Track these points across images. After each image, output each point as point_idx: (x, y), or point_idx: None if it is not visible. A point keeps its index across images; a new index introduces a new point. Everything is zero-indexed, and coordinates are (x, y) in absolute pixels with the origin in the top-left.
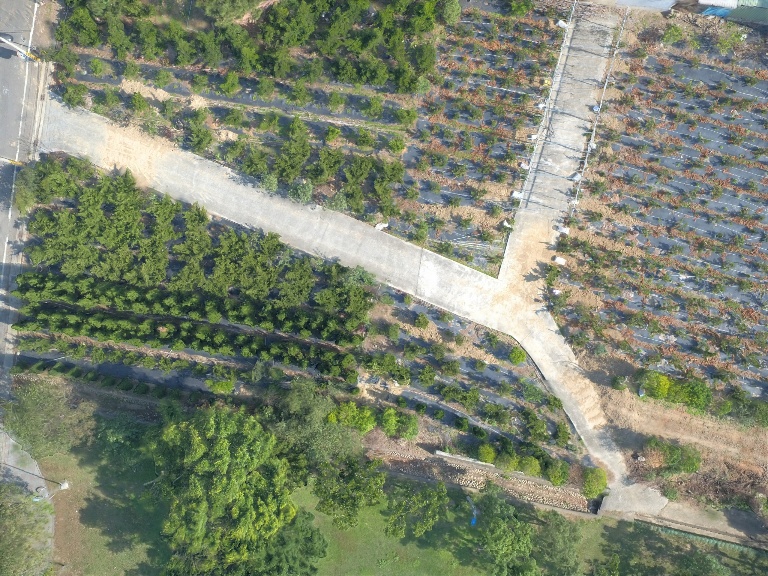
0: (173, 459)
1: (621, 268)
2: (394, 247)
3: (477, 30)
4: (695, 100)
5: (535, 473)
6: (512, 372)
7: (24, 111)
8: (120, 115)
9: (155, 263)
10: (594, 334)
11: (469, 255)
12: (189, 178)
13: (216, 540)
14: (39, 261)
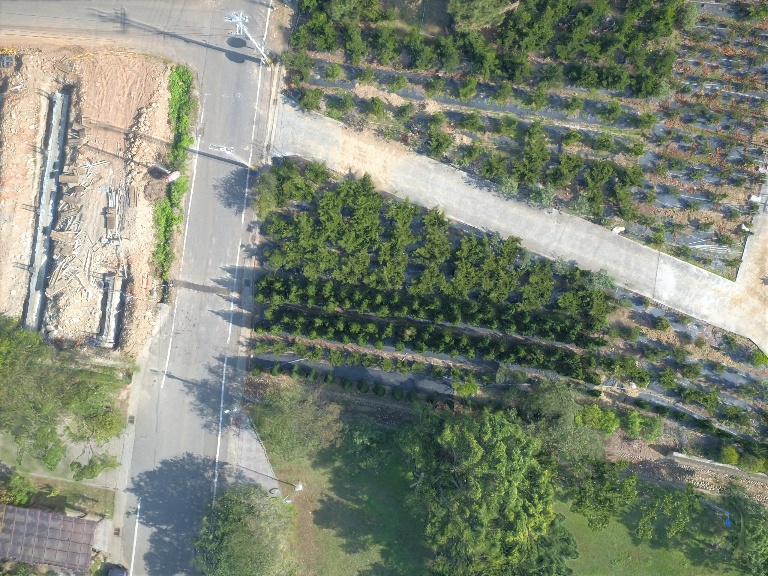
0: (429, 461)
1: None
2: (631, 250)
3: (712, 35)
4: None
5: None
6: (749, 374)
7: (257, 115)
8: (354, 119)
9: (395, 266)
10: None
11: (706, 258)
12: (425, 182)
13: (496, 541)
14: (280, 264)
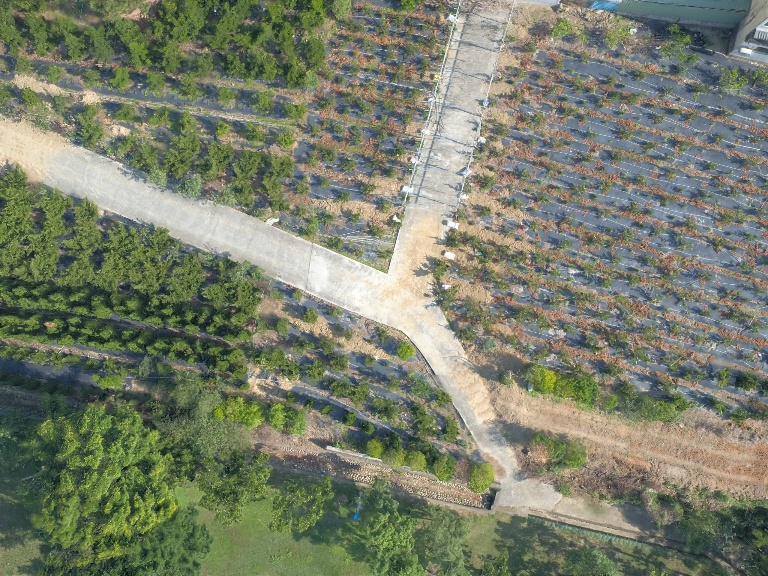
0: None
1: (510, 263)
2: (284, 242)
3: (368, 25)
4: (585, 94)
5: (421, 468)
6: (402, 367)
7: None
8: (12, 110)
9: (45, 258)
10: (484, 329)
11: (359, 250)
12: (81, 173)
13: (87, 535)
14: None
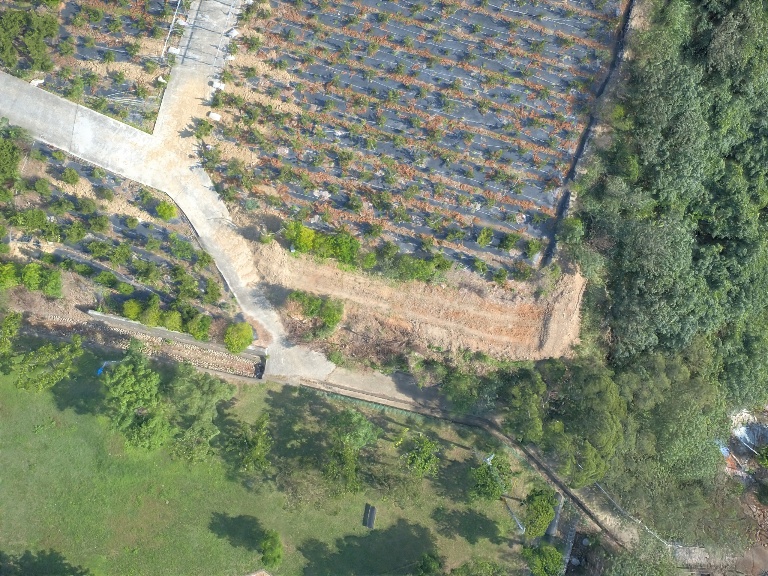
0: None
1: (276, 124)
2: (49, 103)
3: None
4: None
5: (177, 327)
6: (166, 229)
7: None
8: None
9: None
10: (248, 190)
11: None
12: None
13: None
14: None
